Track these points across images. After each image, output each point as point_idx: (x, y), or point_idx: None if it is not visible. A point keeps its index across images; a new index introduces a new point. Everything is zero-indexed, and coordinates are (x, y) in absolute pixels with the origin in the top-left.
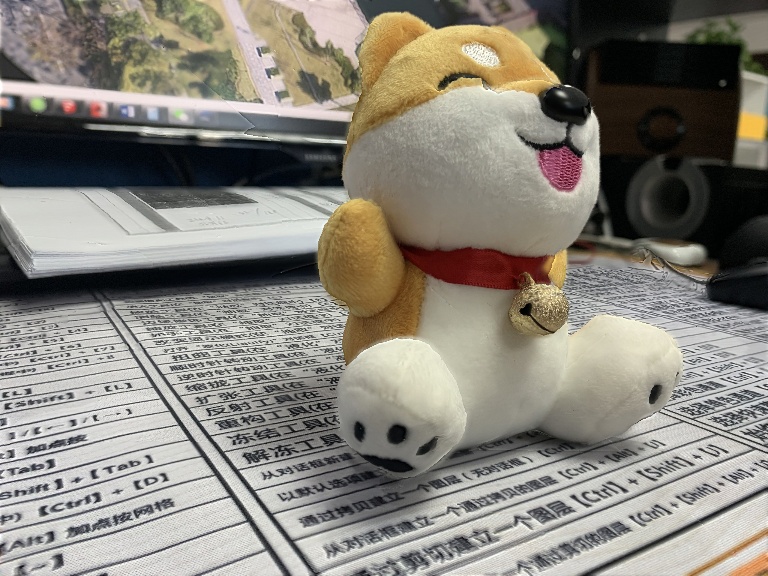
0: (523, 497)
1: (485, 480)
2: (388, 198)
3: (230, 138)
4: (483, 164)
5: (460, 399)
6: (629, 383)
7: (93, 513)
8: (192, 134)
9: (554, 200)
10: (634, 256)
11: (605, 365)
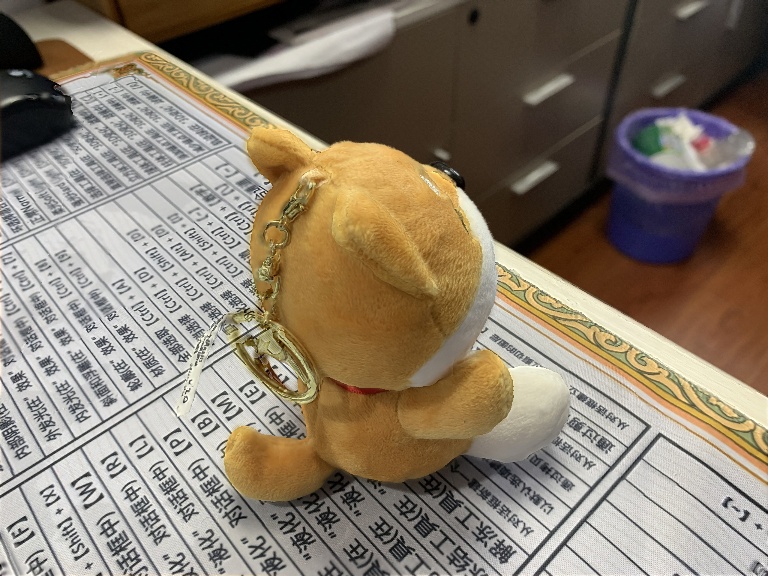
0: None
1: None
2: None
3: None
4: None
5: None
6: None
7: None
8: None
9: None
10: None
11: None
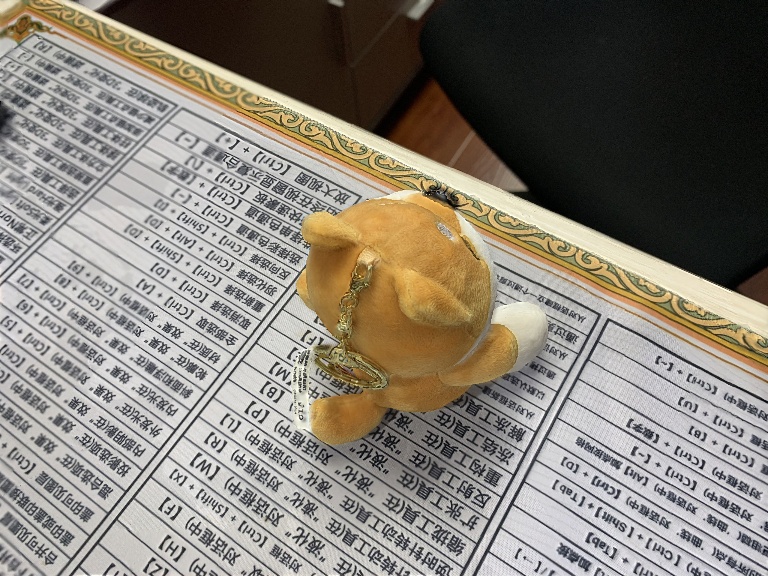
0: None
1: None
2: None
3: None
4: None
5: None
6: None
7: (604, 470)
8: None
9: None
10: None
11: None
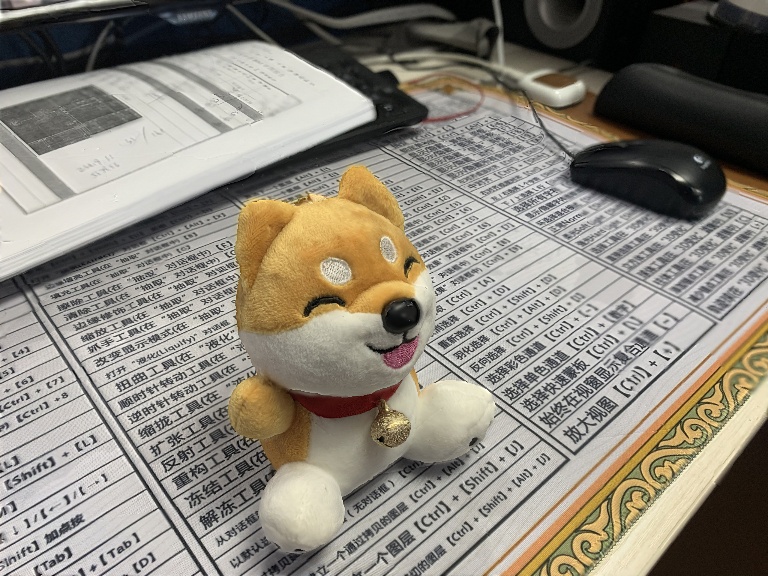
0: (385, 530)
1: (362, 516)
2: (276, 379)
3: (88, 10)
4: (342, 374)
5: (339, 509)
6: (455, 444)
7: None
8: (43, 11)
9: (396, 376)
10: (520, 100)
11: (440, 432)
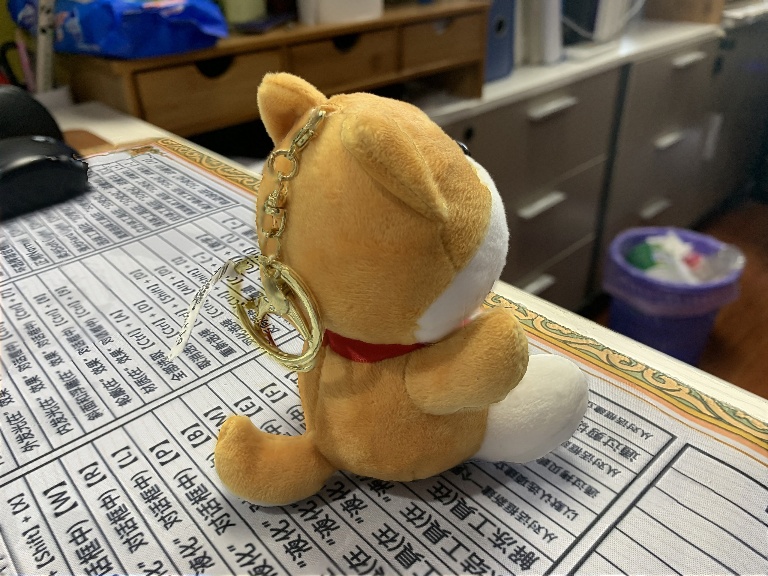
0: None
1: None
2: None
3: None
4: None
5: None
6: None
7: None
8: None
9: None
10: None
11: None
